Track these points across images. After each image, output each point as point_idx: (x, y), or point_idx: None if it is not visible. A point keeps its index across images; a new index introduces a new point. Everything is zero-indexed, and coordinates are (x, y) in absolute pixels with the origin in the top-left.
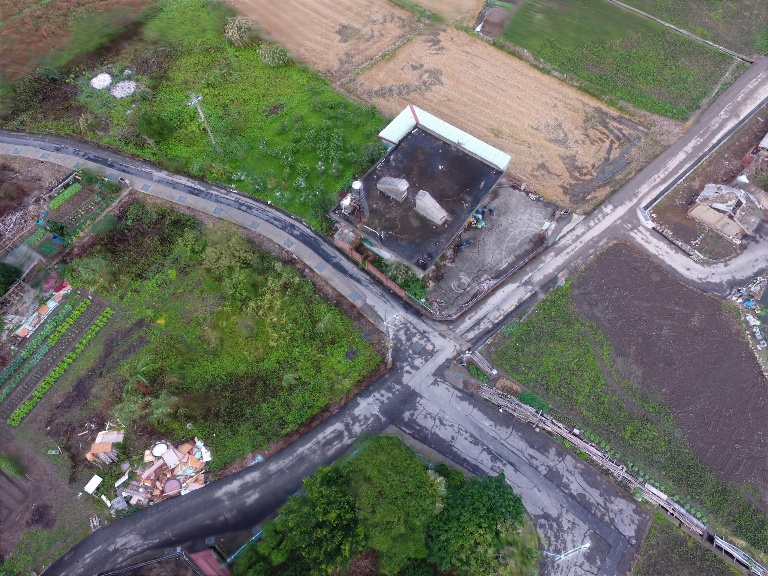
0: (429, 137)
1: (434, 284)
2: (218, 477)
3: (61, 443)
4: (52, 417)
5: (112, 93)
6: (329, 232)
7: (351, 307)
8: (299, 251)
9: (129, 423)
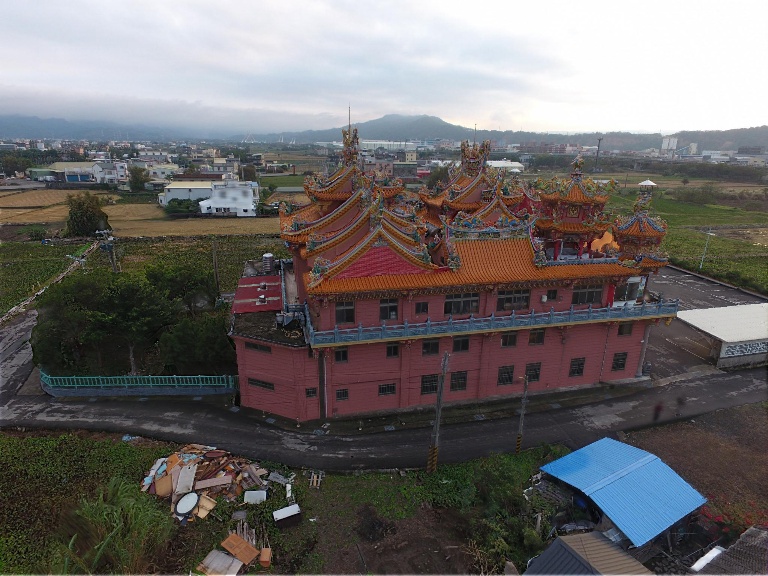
0: None
1: None
2: (174, 444)
3: None
4: None
5: None
6: None
7: None
8: None
9: (181, 573)
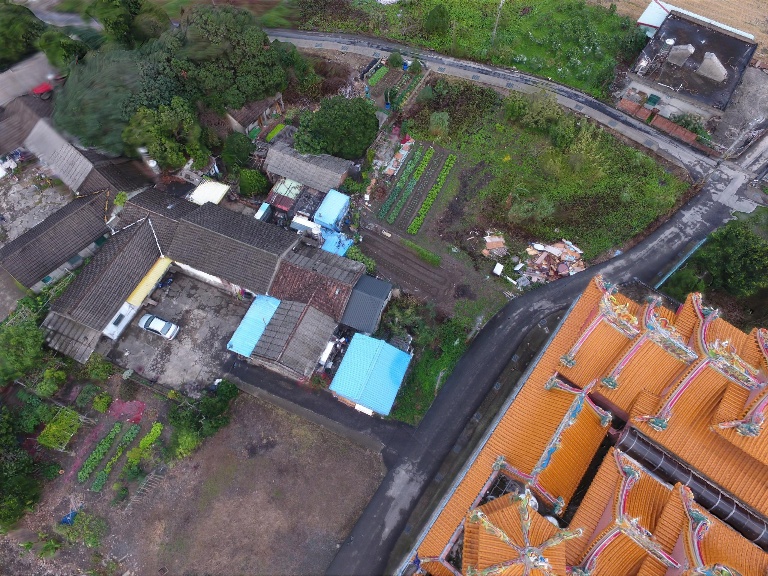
0: (684, 21)
1: (711, 134)
2: (593, 264)
3: (456, 245)
4: (440, 228)
5: (378, 1)
6: (609, 99)
7: (649, 151)
8: (590, 113)
9: (504, 231)
